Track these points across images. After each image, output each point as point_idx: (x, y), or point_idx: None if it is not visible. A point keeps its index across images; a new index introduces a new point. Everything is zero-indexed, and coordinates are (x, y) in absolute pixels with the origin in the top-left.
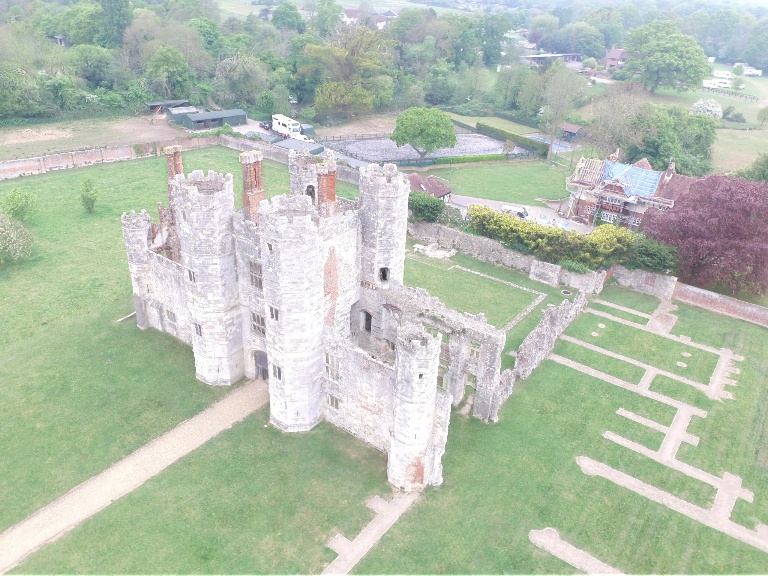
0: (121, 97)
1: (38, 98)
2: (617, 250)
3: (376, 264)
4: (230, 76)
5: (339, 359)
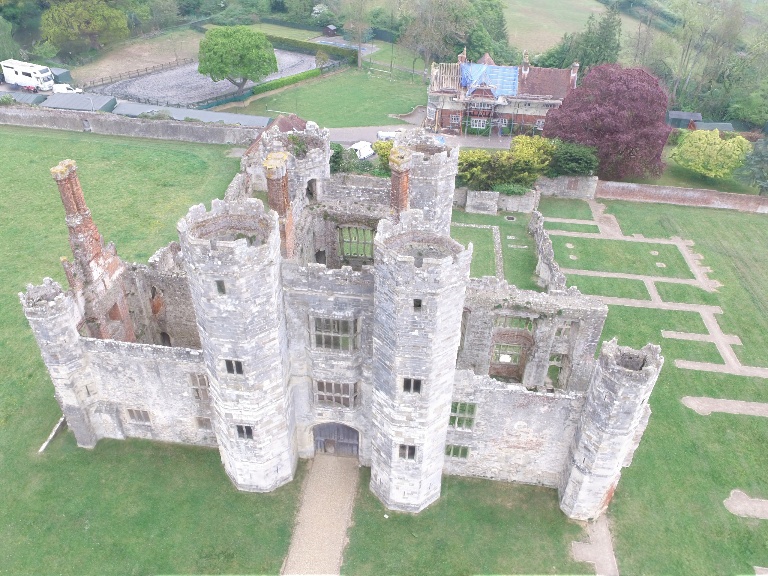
0: None
1: None
2: (541, 162)
3: None
4: None
5: (478, 405)
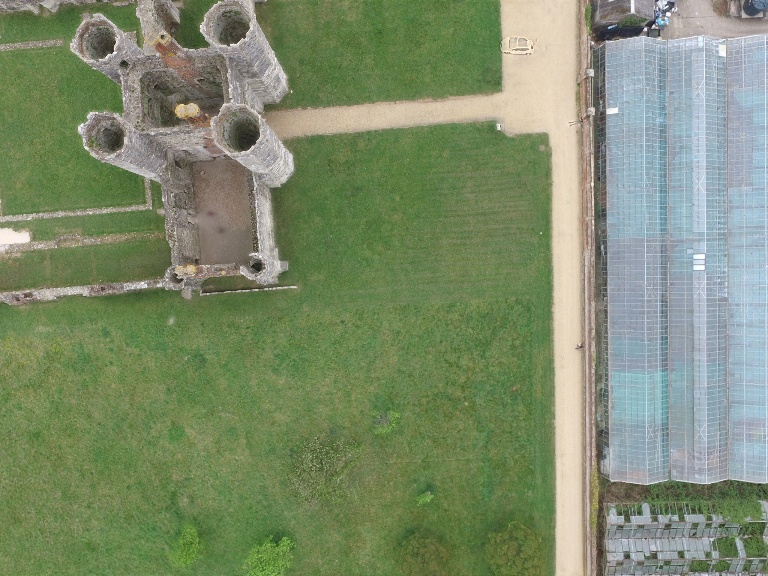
0: None
1: None
2: None
3: None
4: None
5: None
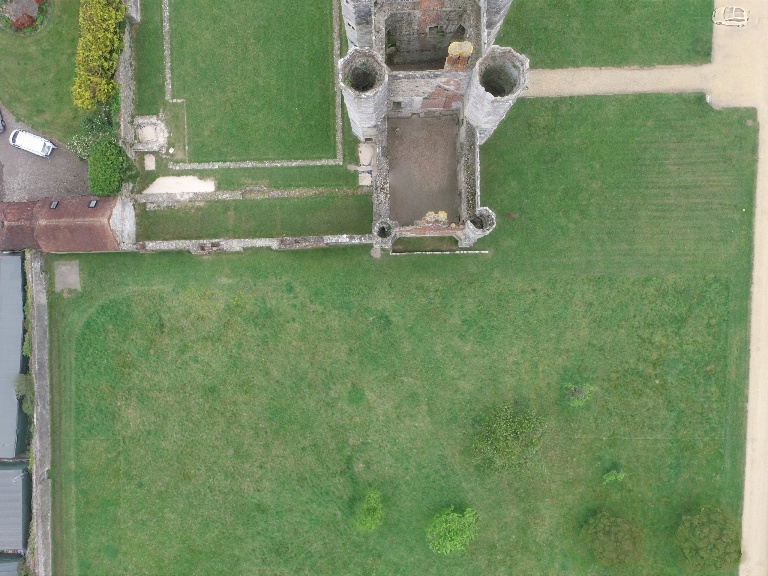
0: None
1: None
2: None
3: None
4: None
5: None
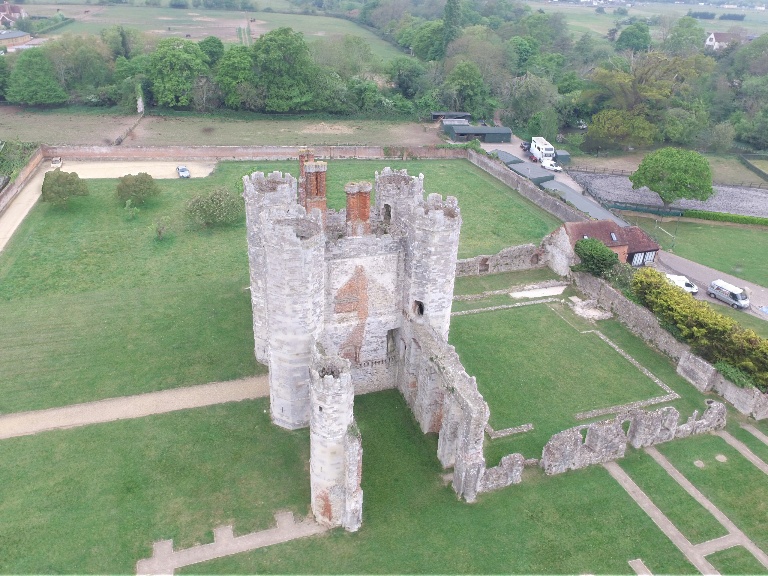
0: (412, 104)
1: (344, 98)
2: None
3: (411, 295)
4: (514, 94)
5: None
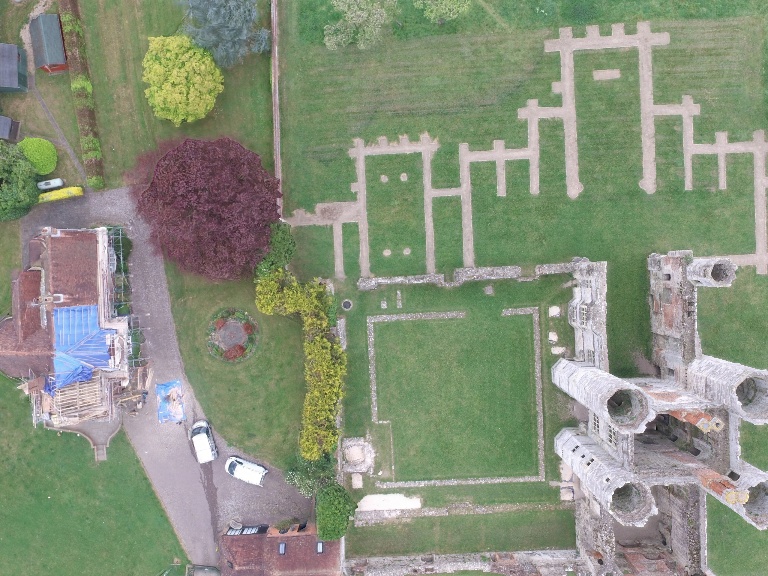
0: None
1: None
2: None
3: None
4: None
5: None
